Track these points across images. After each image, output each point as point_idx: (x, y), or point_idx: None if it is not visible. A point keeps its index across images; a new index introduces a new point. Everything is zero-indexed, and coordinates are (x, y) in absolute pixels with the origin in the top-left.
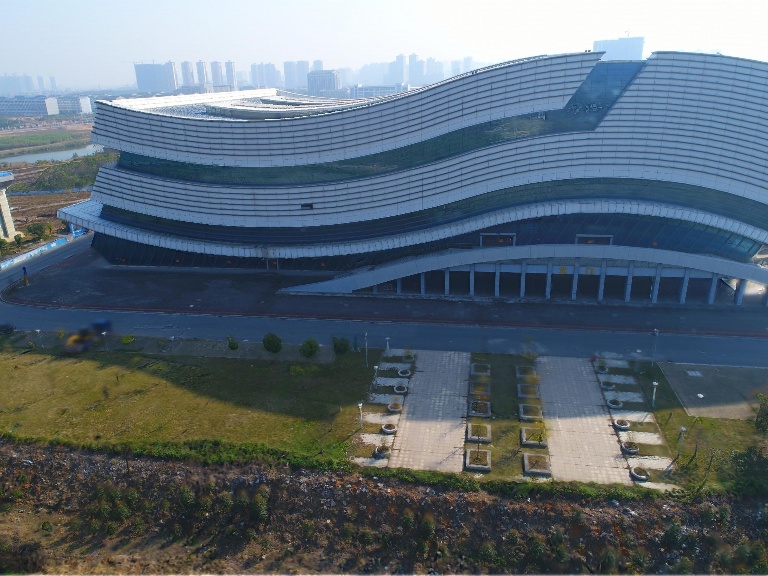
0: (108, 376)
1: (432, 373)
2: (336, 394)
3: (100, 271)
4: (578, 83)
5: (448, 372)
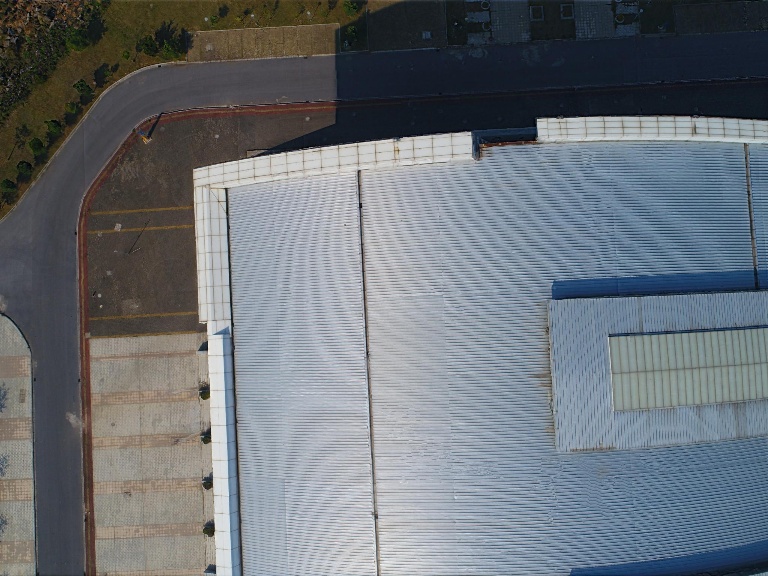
0: None
1: (600, 3)
2: None
3: None
4: None
5: (589, 6)
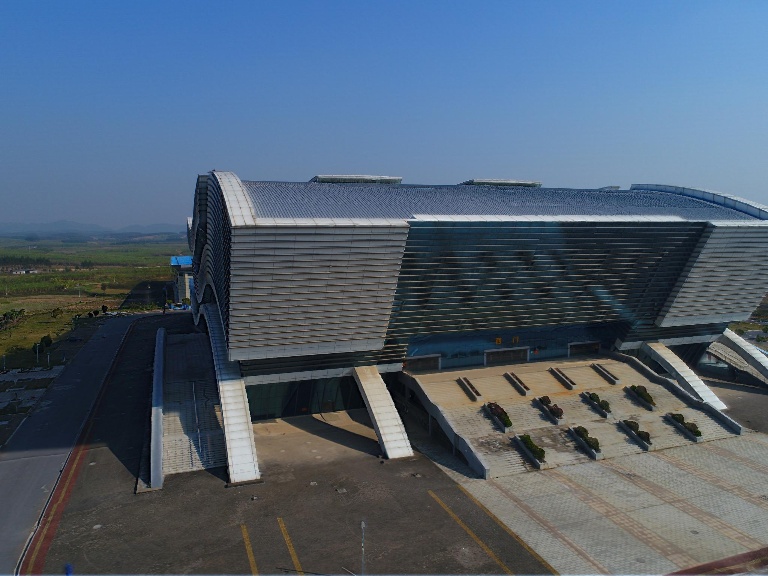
0: (36, 340)
1: None
2: (2, 366)
3: (189, 316)
4: (198, 202)
5: None
